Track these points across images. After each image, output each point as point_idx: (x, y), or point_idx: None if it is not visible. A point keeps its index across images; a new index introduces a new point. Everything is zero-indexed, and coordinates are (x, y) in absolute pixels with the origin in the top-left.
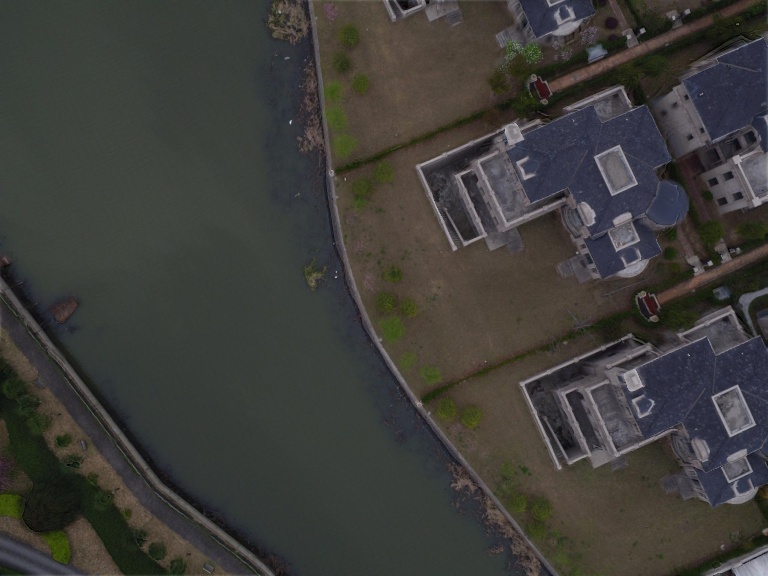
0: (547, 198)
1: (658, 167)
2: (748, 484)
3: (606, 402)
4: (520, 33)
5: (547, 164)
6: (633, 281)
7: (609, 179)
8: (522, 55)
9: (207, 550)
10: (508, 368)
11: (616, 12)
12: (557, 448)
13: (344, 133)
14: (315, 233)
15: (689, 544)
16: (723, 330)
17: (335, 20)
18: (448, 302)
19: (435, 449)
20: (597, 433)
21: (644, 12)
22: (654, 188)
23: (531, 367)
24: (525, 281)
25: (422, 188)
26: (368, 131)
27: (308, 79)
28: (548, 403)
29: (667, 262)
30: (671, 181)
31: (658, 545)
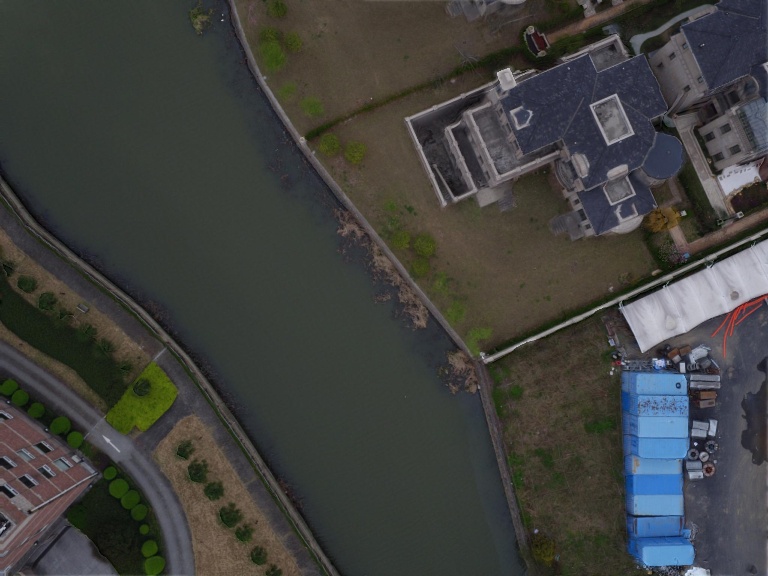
0: None
1: None
2: (632, 209)
3: (489, 129)
4: None
5: None
6: (520, 12)
7: None
8: None
9: (82, 291)
10: (394, 106)
11: None
12: (445, 191)
13: None
14: None
15: (577, 286)
16: (609, 59)
17: None
18: (334, 39)
19: (321, 194)
20: (480, 161)
21: None
22: None
23: (418, 105)
24: (413, 20)
25: None
26: None
27: None
28: (440, 155)
29: (557, 2)
30: None
31: (546, 287)
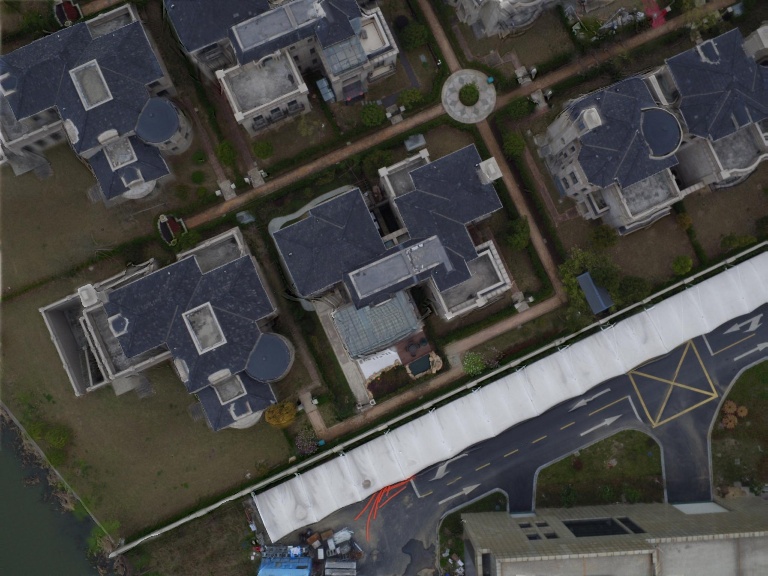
0: (35, 116)
1: (150, 84)
2: (245, 407)
3: None
4: None
5: (22, 79)
6: (147, 203)
7: (85, 94)
8: None
9: None
10: (33, 294)
11: None
12: (87, 376)
13: None
14: None
15: (215, 473)
16: (231, 252)
17: None
18: None
19: None
20: None
21: None
22: (140, 104)
23: (56, 293)
24: (54, 207)
25: None
26: None
27: None
28: None
29: (196, 186)
30: (202, 104)
31: (183, 474)
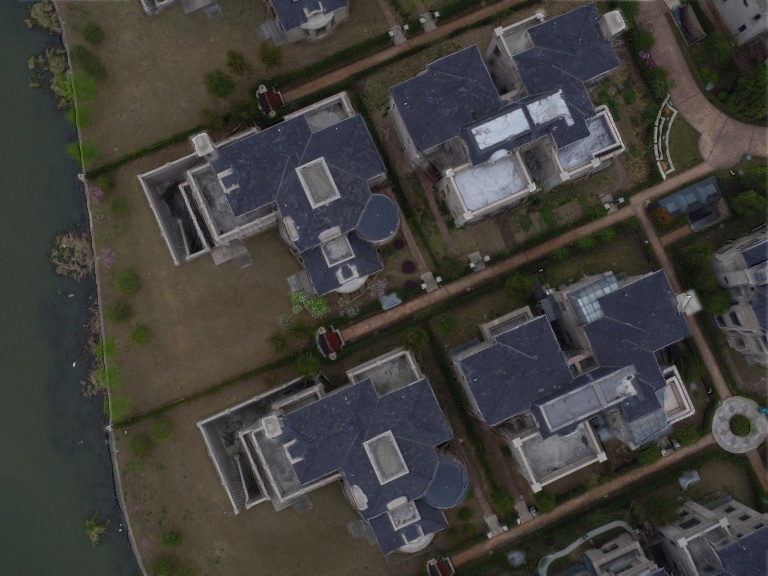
0: None
1: (438, 445)
2: None
3: None
4: (309, 281)
5: (313, 450)
6: (420, 552)
7: (379, 466)
8: (306, 310)
9: None
10: None
11: (415, 254)
12: None
13: (125, 383)
14: (99, 483)
15: None
16: None
17: (112, 267)
18: (232, 565)
19: None
20: None
21: (444, 254)
22: (431, 470)
23: None
24: (314, 542)
25: (205, 445)
26: (150, 382)
27: (92, 319)
28: None
29: (463, 523)
30: (469, 437)
31: None
